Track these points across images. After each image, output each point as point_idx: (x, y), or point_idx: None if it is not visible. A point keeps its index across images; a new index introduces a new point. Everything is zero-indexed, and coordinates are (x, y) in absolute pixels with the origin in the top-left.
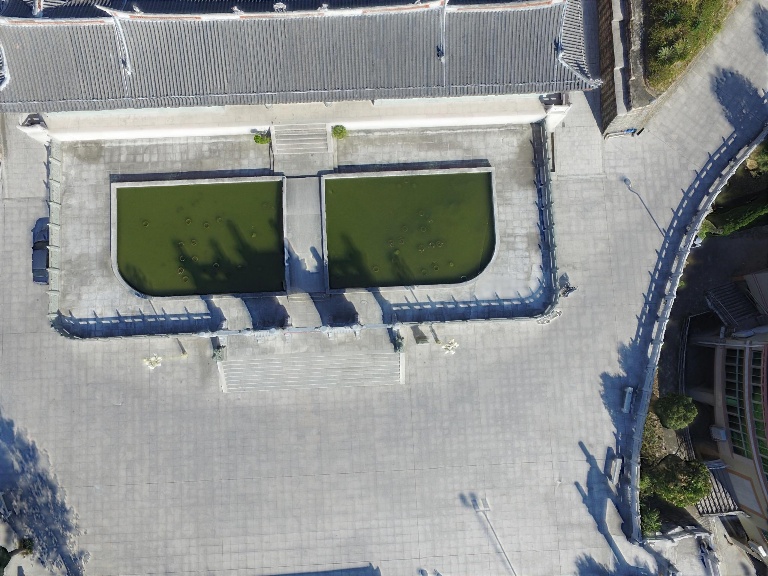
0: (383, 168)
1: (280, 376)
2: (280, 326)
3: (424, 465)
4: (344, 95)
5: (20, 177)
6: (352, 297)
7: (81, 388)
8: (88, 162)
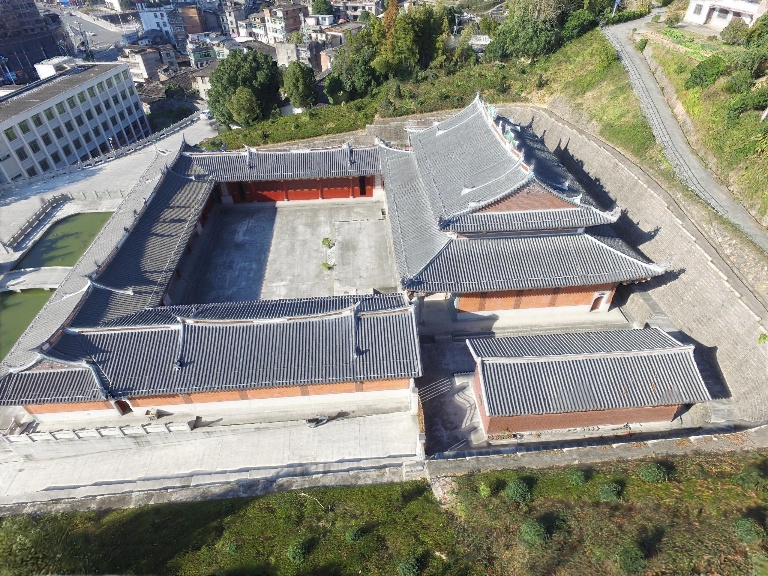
0: None
1: None
2: None
3: None
4: None
5: None
6: None
7: None
8: None
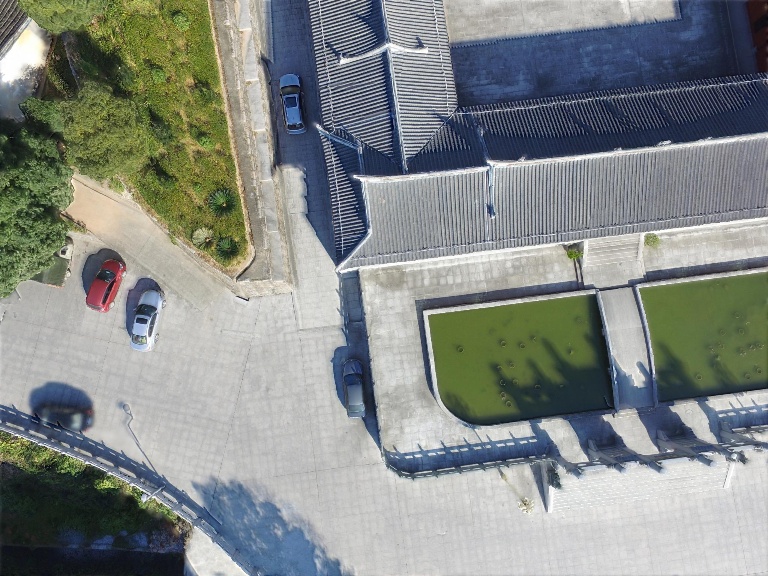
0: (691, 271)
1: (607, 492)
2: (609, 444)
3: (756, 569)
4: (706, 219)
5: (313, 307)
6: (676, 407)
7: (403, 520)
8: (391, 289)
